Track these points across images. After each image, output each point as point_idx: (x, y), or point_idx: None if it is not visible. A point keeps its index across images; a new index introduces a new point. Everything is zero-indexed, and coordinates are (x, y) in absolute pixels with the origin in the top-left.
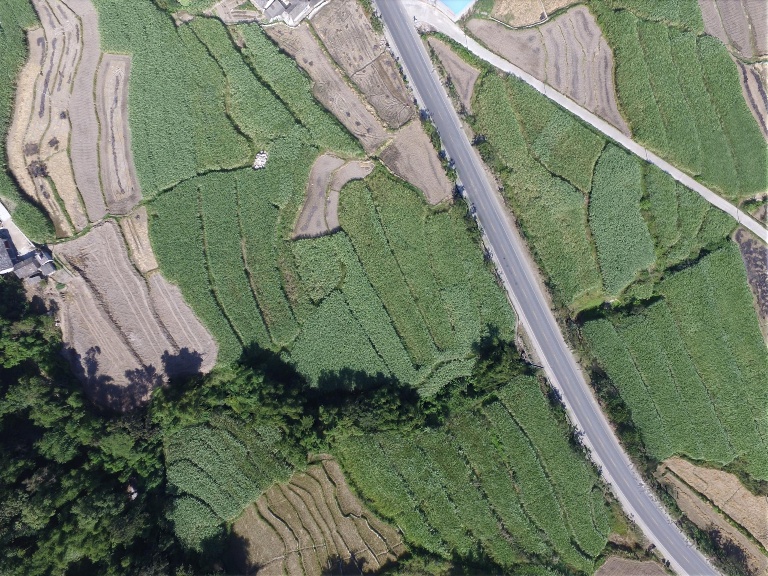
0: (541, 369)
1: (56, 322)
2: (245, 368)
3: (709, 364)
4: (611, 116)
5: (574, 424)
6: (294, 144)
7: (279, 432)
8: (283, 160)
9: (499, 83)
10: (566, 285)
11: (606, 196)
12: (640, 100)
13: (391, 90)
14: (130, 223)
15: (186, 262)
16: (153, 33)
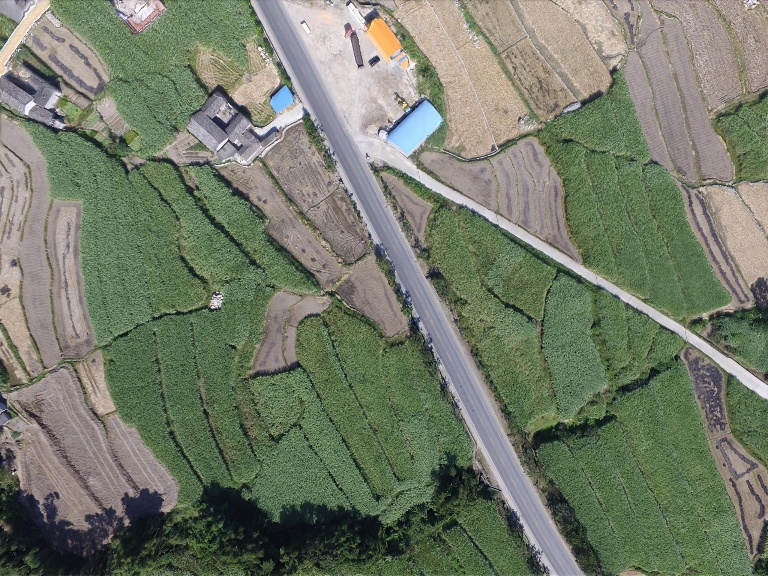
0: (499, 492)
1: (13, 471)
2: (206, 506)
3: (660, 480)
4: (562, 243)
5: (532, 544)
6: (249, 286)
7: (242, 569)
8: (239, 302)
9: (451, 218)
10: (521, 412)
11: (558, 324)
12: (589, 229)
13: (346, 225)
14: (86, 367)
15: (144, 406)
16: (103, 181)
